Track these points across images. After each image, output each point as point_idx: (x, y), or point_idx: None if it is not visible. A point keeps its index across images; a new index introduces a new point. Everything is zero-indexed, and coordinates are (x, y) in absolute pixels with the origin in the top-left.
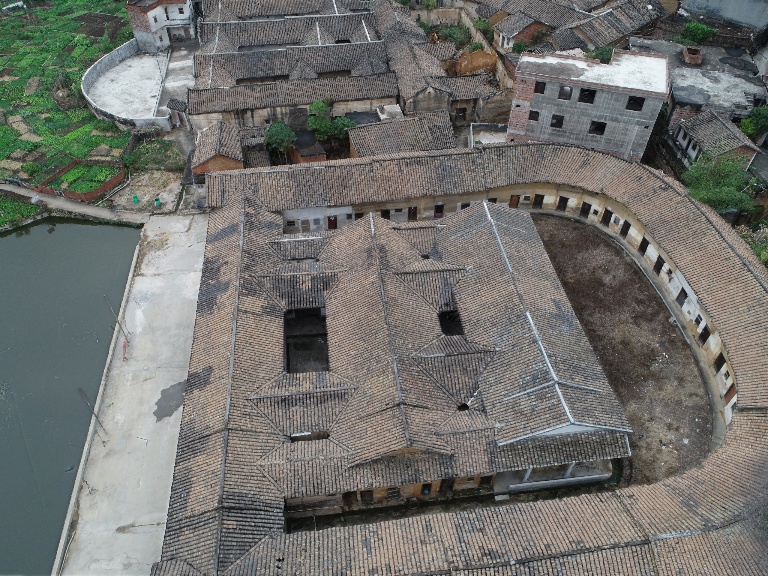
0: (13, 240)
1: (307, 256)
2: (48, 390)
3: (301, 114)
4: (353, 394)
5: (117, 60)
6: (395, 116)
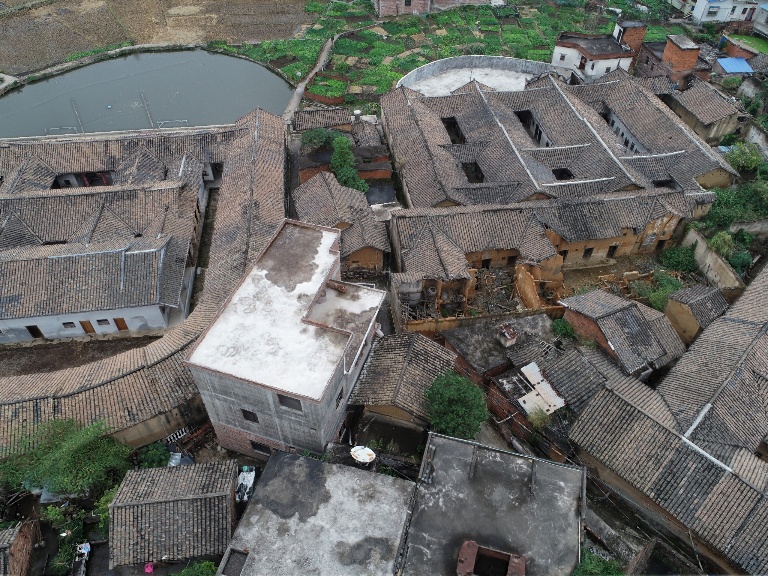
0: (287, 87)
1: (168, 175)
2: (134, 119)
3: (374, 152)
4: (8, 193)
5: (521, 68)
6: (376, 215)
